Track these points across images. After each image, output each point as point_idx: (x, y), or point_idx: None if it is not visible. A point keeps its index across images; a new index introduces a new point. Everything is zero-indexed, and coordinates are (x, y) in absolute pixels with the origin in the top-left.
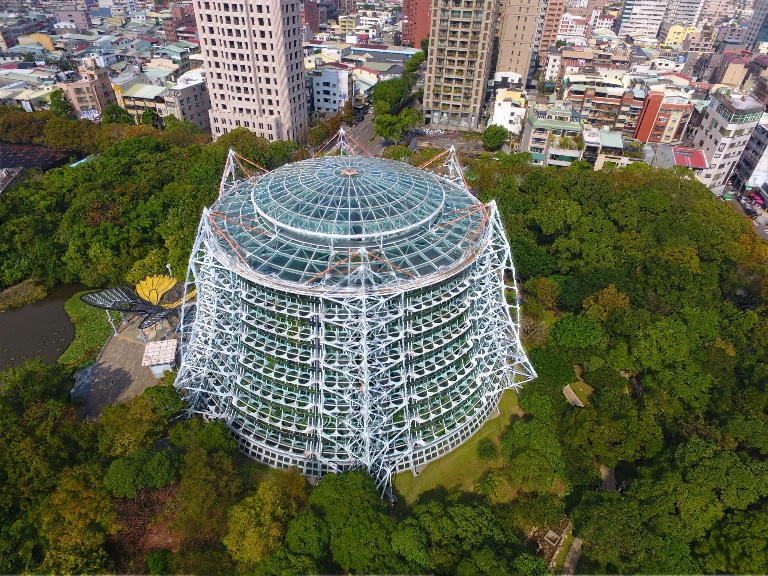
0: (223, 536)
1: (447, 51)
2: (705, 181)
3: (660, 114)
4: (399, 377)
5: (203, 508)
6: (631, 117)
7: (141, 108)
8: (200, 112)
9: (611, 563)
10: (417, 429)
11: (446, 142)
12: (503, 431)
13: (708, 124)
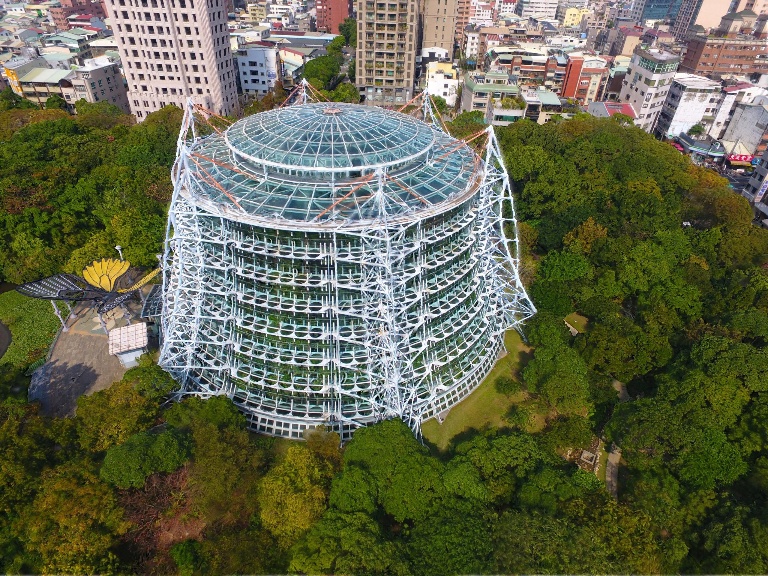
0: (253, 514)
1: (376, 25)
2: None
3: (582, 78)
4: (416, 319)
5: (226, 486)
6: (556, 83)
7: (43, 95)
8: (115, 97)
9: None
10: (436, 374)
11: None
12: None
13: (632, 78)
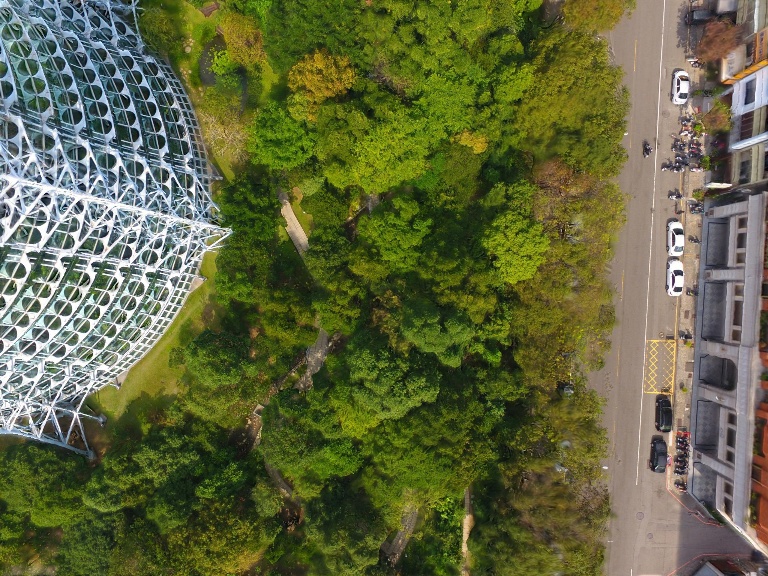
0: None
1: None
2: None
3: None
4: (4, 366)
5: None
6: None
7: None
8: None
9: None
10: None
11: None
12: (208, 305)
13: None
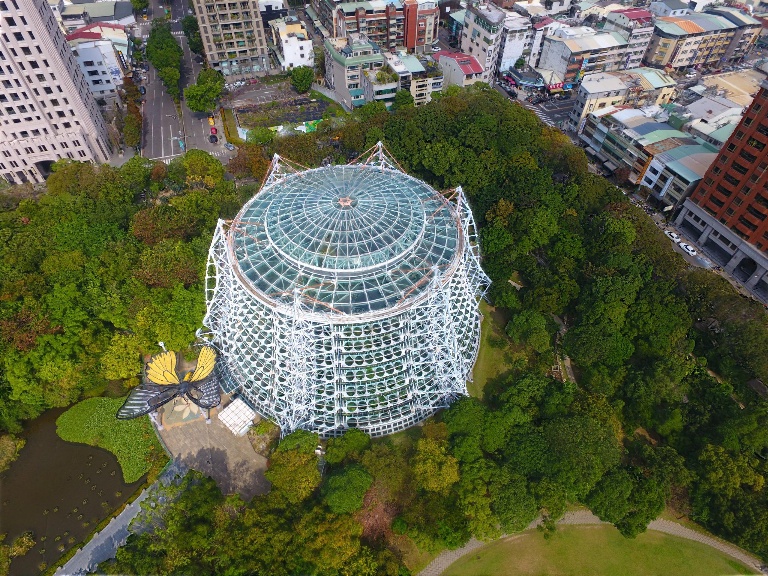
0: None
1: None
2: (484, 81)
3: (419, 21)
4: None
5: (398, 481)
6: (398, 27)
7: None
8: None
9: (592, 362)
10: None
11: (255, 95)
12: (493, 326)
13: (471, 33)
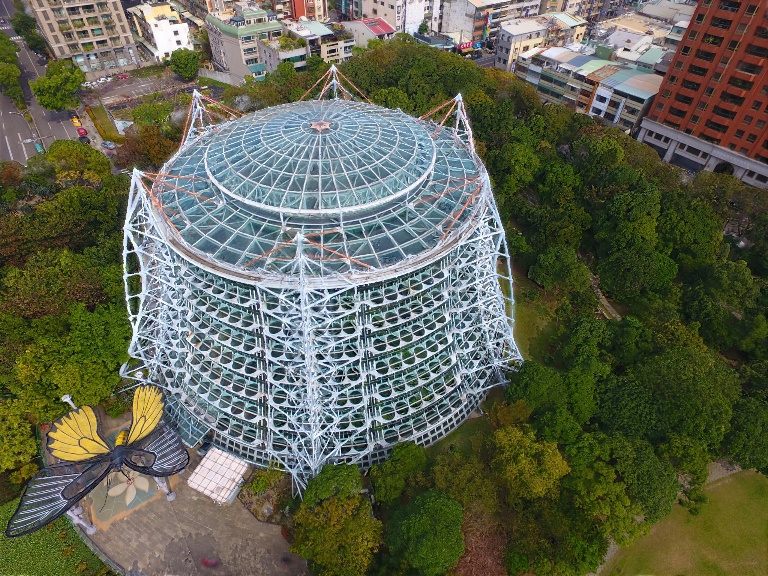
0: None
1: None
2: None
3: None
4: None
5: (492, 497)
6: (283, 5)
7: None
8: None
9: None
10: None
11: (129, 89)
12: None
13: None
